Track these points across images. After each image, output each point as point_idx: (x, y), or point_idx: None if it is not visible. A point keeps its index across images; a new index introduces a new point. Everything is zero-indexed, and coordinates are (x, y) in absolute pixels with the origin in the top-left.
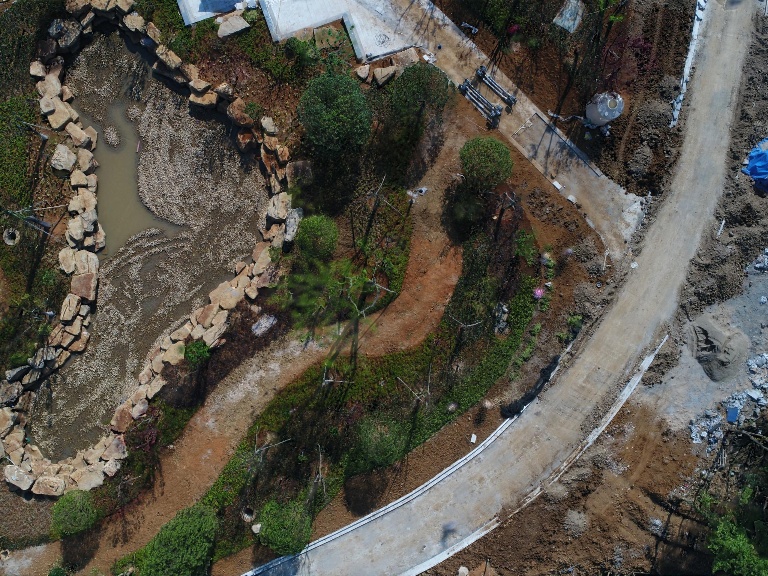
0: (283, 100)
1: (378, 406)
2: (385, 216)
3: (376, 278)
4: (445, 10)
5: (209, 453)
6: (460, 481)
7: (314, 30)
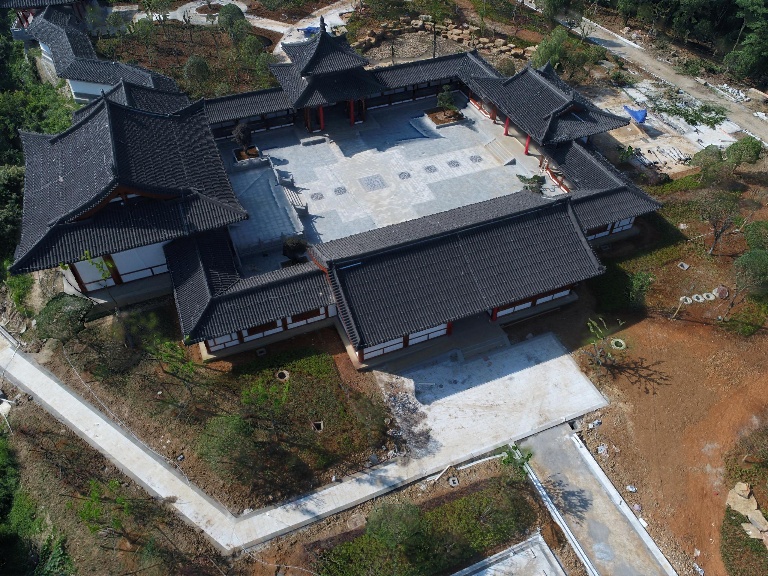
0: None
1: (492, 3)
2: (419, 3)
3: (443, 3)
4: (337, 1)
5: (524, 33)
6: None
7: (345, 17)
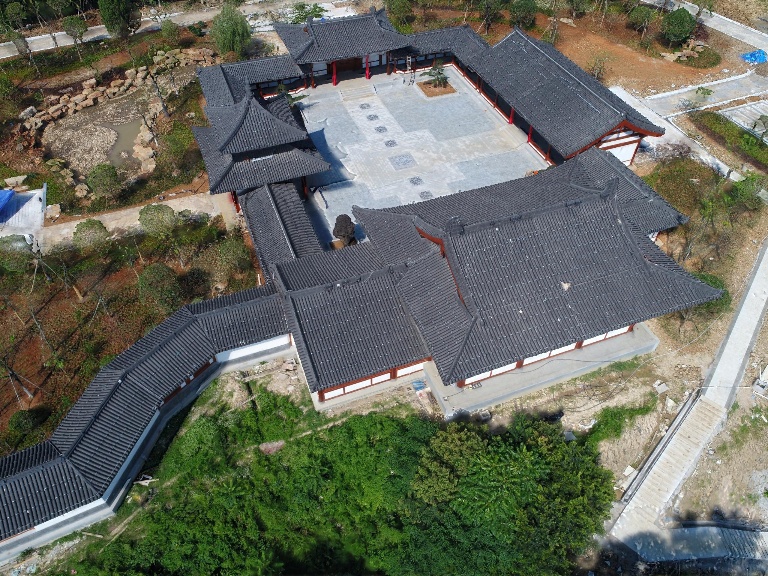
0: (6, 157)
1: (21, 66)
2: None
3: None
4: None
5: (114, 59)
6: (1, 56)
7: None
